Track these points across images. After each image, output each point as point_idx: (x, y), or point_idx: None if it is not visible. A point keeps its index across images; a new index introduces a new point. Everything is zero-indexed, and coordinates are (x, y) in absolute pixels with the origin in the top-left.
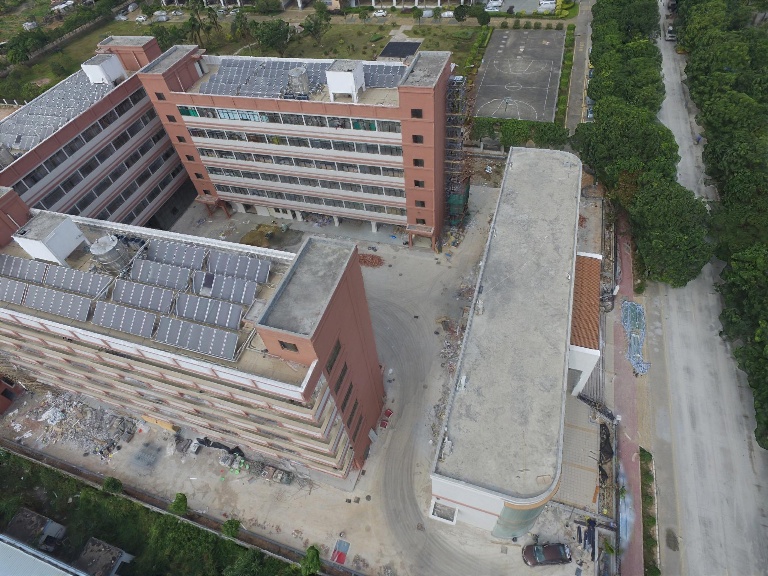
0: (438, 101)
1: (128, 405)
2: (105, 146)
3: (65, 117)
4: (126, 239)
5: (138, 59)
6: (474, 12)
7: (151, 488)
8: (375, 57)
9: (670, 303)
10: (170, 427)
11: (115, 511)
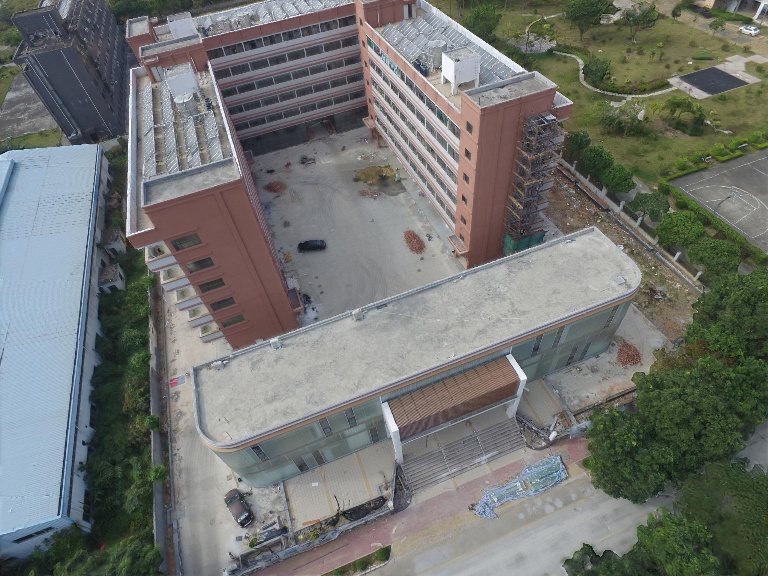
0: (497, 127)
1: None
2: (317, 45)
3: (298, 12)
4: (210, 104)
5: None
6: None
7: None
8: (672, 76)
9: (602, 504)
10: None
11: (140, 262)
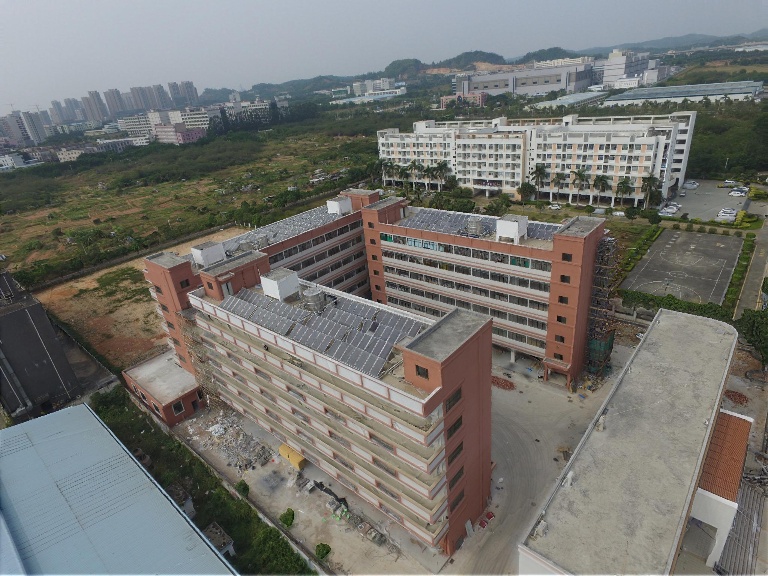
0: (588, 251)
1: (276, 429)
2: (323, 252)
3: (307, 228)
4: (325, 296)
5: (363, 203)
6: (646, 214)
7: (266, 507)
8: None
9: None
10: (297, 462)
11: (236, 510)
